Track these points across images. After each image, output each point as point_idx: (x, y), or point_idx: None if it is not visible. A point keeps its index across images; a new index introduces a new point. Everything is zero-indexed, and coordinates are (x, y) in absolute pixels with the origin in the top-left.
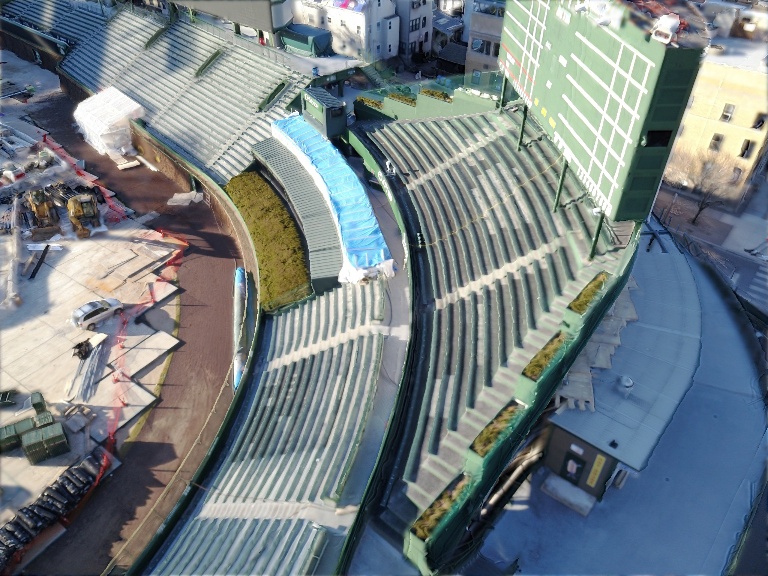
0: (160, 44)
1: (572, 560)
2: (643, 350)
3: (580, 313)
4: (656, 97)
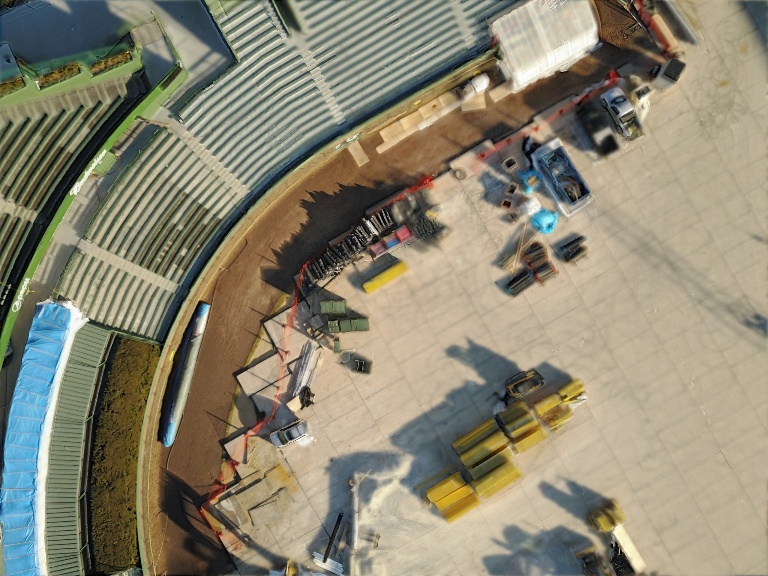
0: None
1: (72, 52)
2: None
3: None
4: None
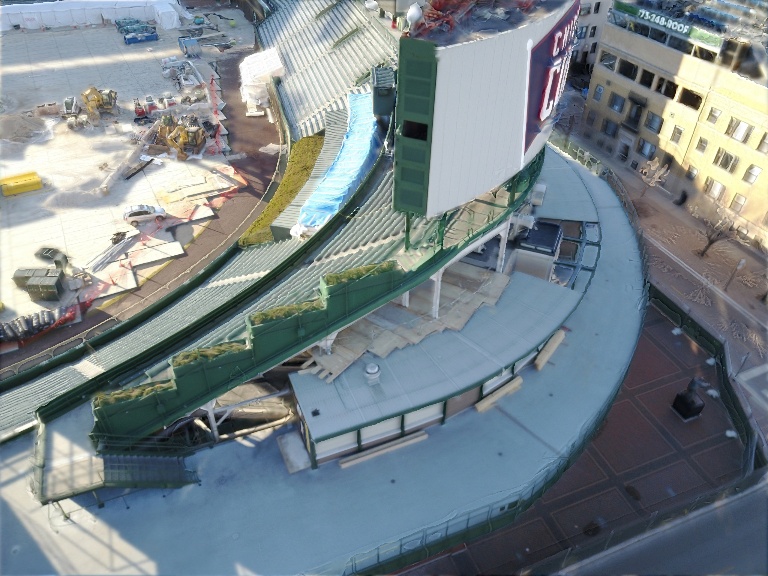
0: (325, 17)
1: (245, 497)
2: (434, 356)
3: (328, 284)
4: (403, 86)
